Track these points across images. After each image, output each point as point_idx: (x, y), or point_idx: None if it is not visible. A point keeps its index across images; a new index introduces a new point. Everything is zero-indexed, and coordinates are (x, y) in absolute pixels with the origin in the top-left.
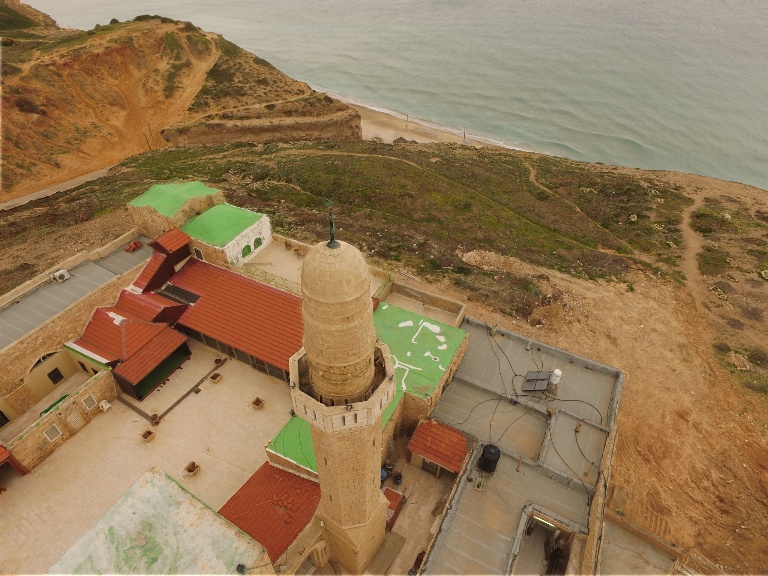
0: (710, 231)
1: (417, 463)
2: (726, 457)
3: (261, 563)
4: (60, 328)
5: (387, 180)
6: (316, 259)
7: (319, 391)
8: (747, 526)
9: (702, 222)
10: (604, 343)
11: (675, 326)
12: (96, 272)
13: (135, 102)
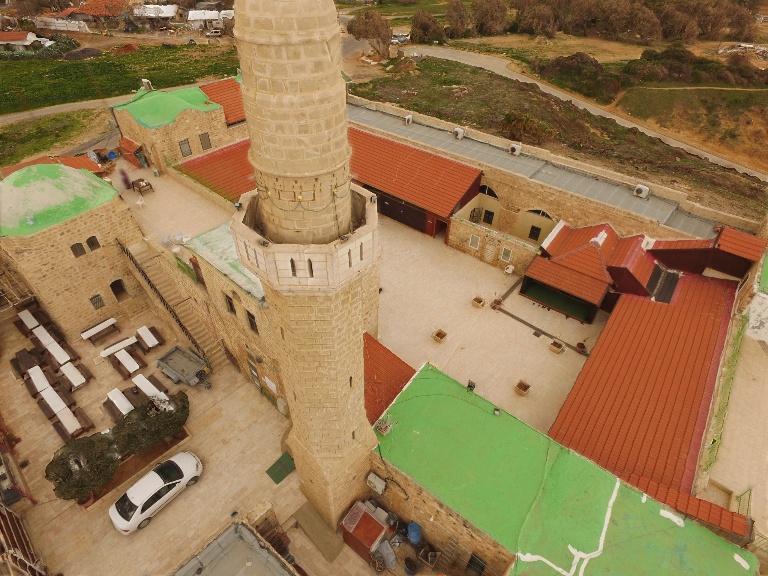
0: None
1: None
2: None
3: None
4: (571, 206)
5: None
6: None
7: None
8: None
9: None
10: None
11: None
12: (661, 211)
13: None
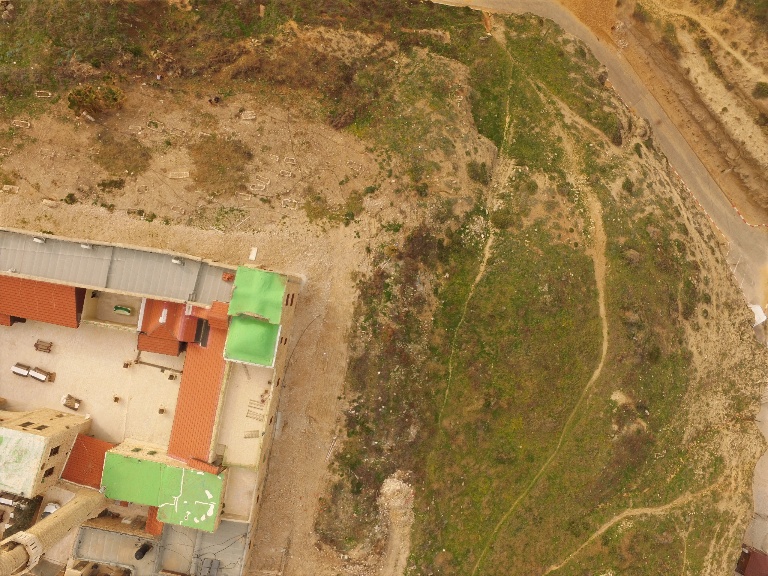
0: None
1: None
2: None
3: None
4: None
5: (524, 367)
6: None
7: None
8: None
9: None
10: None
11: None
12: (191, 276)
13: None
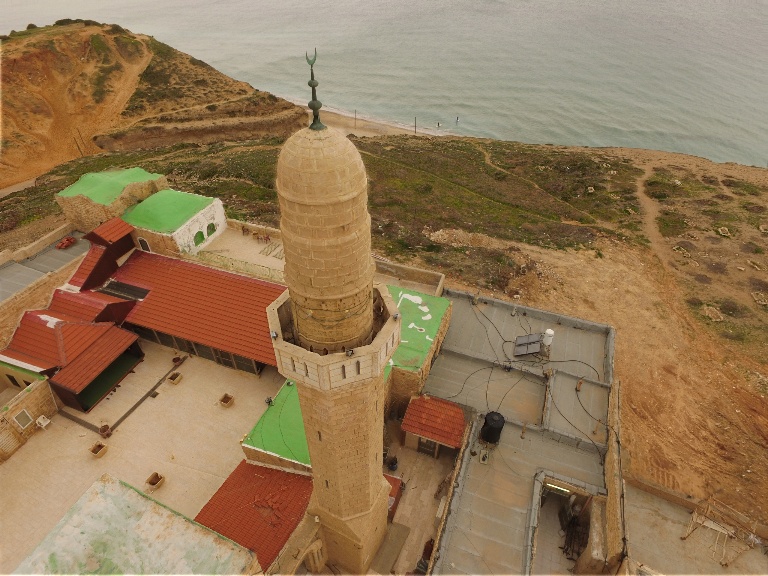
0: (664, 196)
1: (412, 445)
2: (718, 405)
3: (250, 572)
4: None
5: None
6: (297, 145)
7: (308, 340)
8: (752, 470)
9: (655, 189)
10: (583, 308)
11: (647, 286)
12: (22, 273)
13: (61, 109)
